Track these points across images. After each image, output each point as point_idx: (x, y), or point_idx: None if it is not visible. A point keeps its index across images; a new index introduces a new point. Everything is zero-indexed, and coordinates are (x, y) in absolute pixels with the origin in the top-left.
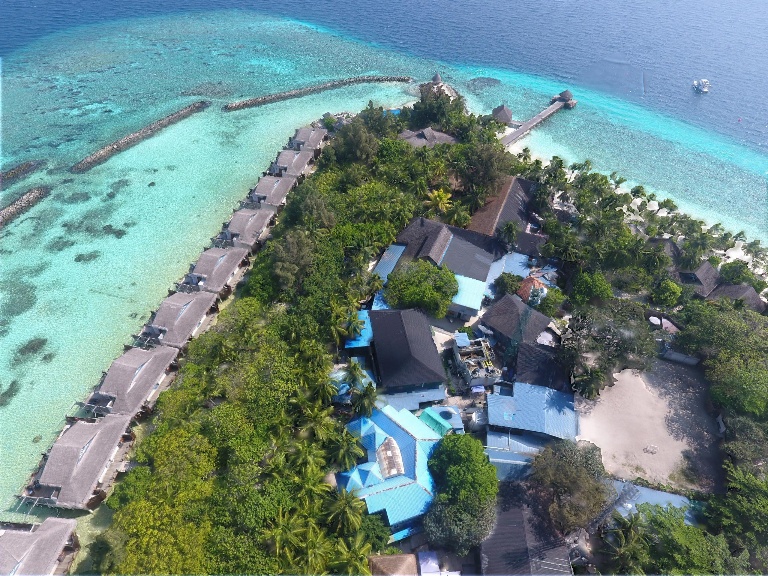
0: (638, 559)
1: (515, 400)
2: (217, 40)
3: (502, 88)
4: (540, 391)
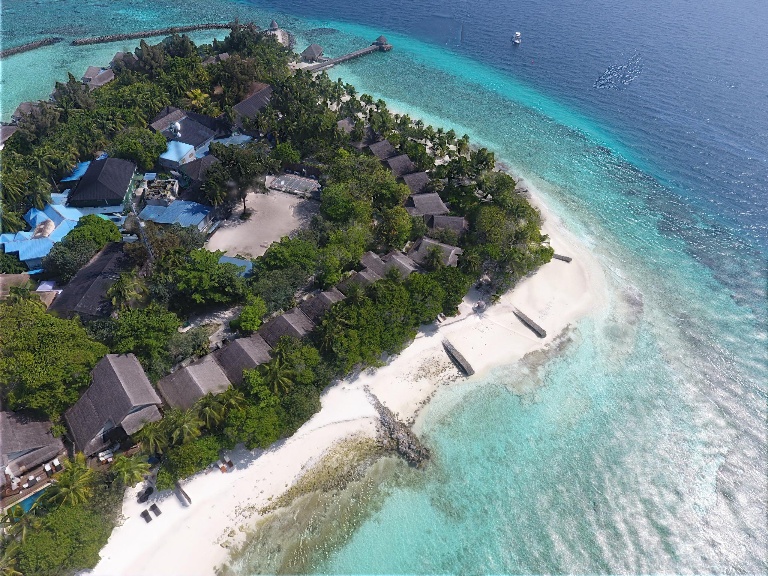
0: (163, 267)
1: (166, 208)
2: None
3: (336, 36)
4: (187, 204)
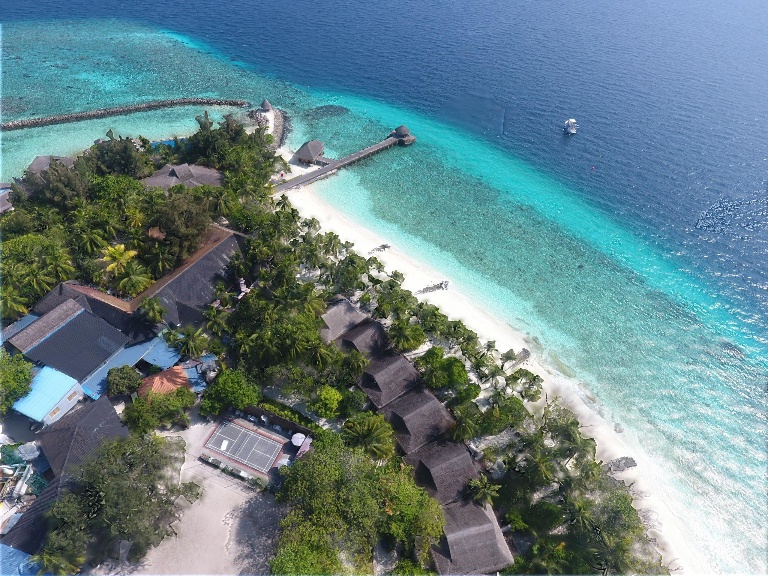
0: None
1: None
2: (63, 50)
3: (345, 118)
4: (15, 562)
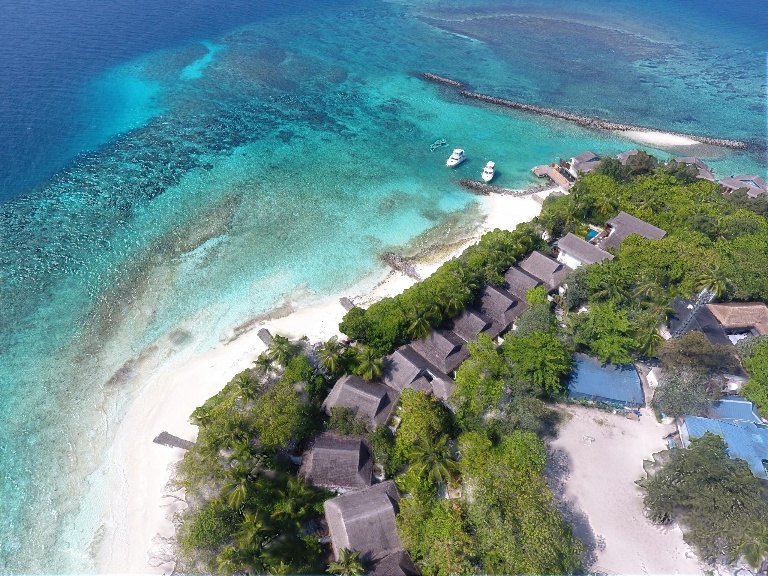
0: None
1: (759, 456)
2: None
3: None
4: None
